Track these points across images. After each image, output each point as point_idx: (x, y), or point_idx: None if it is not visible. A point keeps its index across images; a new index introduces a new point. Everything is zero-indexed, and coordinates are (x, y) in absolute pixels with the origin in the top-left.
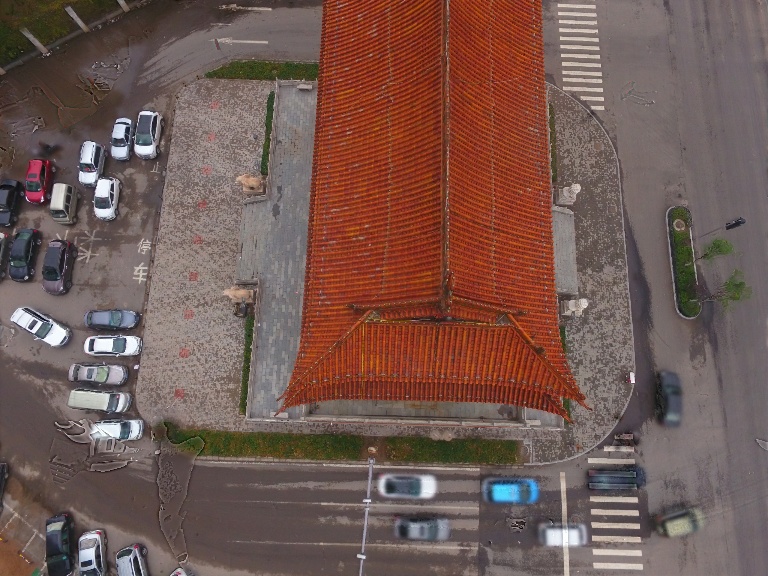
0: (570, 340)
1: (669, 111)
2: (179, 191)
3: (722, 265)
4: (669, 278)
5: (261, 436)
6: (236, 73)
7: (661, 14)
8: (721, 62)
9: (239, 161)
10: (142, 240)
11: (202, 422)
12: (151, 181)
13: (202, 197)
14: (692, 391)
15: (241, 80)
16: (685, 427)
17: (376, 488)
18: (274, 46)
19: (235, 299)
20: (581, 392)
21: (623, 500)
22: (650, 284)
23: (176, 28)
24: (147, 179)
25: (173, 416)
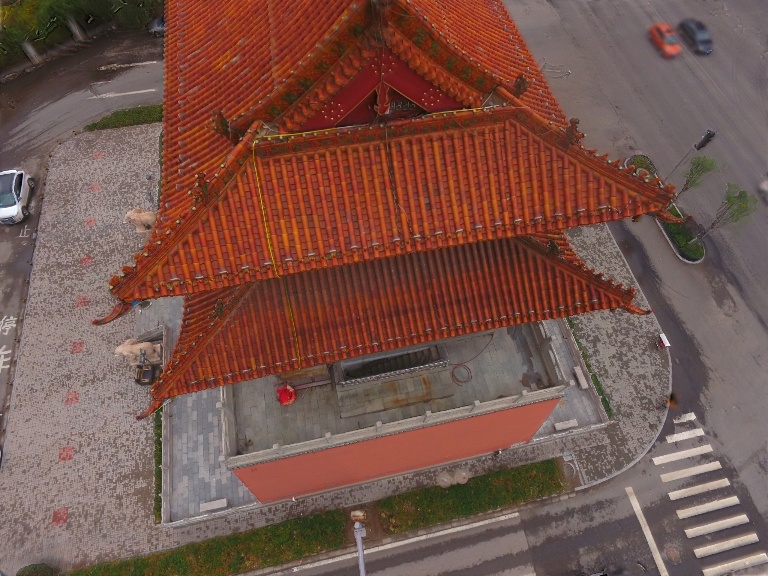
0: (574, 316)
1: (587, 79)
2: (54, 251)
3: (704, 203)
4: (656, 227)
5: (191, 548)
6: (120, 121)
7: (547, 8)
8: (618, 34)
9: (130, 205)
10: (4, 318)
11: (98, 551)
12: (17, 248)
13: (85, 252)
14: (737, 342)
15: (127, 127)
16: (750, 387)
17: None
18: (162, 92)
19: (132, 356)
20: (611, 375)
21: (720, 505)
22: (638, 237)
23: (48, 94)
24: (12, 246)
25: (51, 554)
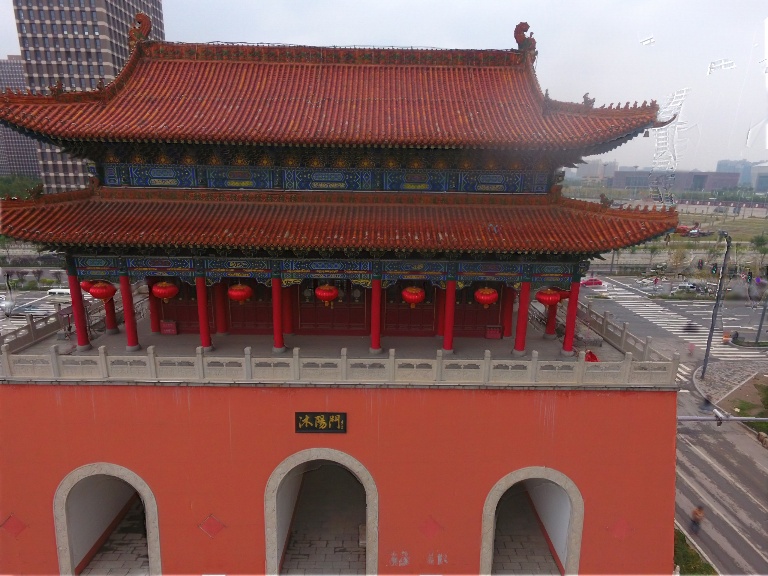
0: None
1: None
2: None
3: None
4: None
5: None
6: None
7: None
8: None
9: None
10: None
11: None
12: None
13: None
14: None
15: None
16: None
17: (698, 515)
18: None
19: None
20: None
21: None
22: None
23: None
24: None
25: None
